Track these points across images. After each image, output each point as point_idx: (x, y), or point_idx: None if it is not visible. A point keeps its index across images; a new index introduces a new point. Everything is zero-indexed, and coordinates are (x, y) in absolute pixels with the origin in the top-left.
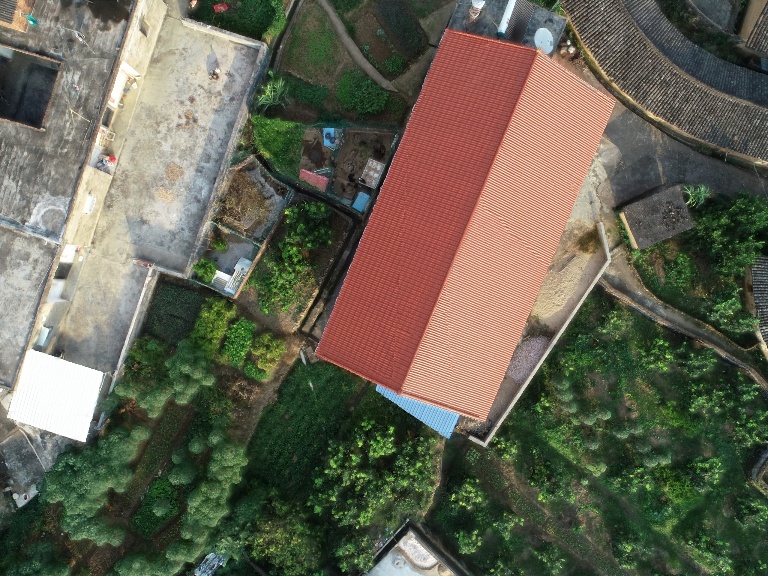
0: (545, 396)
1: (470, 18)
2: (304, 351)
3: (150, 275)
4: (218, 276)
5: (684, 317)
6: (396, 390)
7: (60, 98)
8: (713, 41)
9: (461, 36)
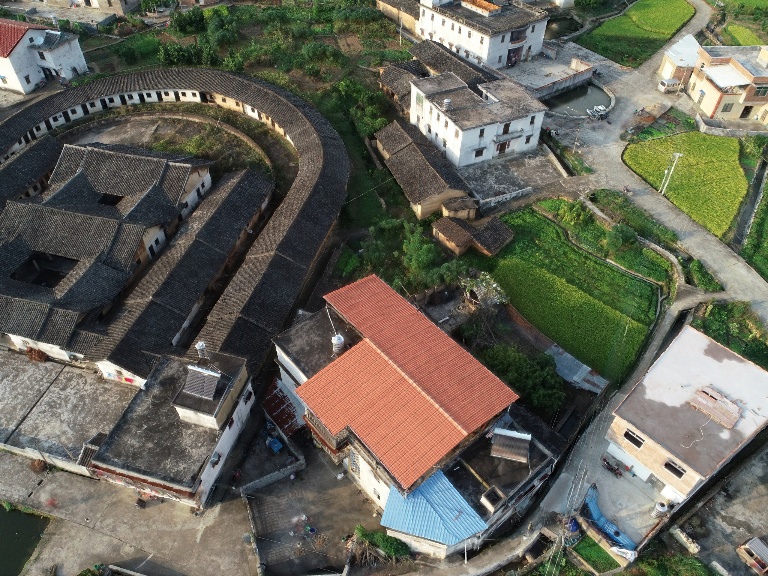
0: None
1: None
2: None
3: None
4: None
5: None
6: None
7: None
8: None
9: None
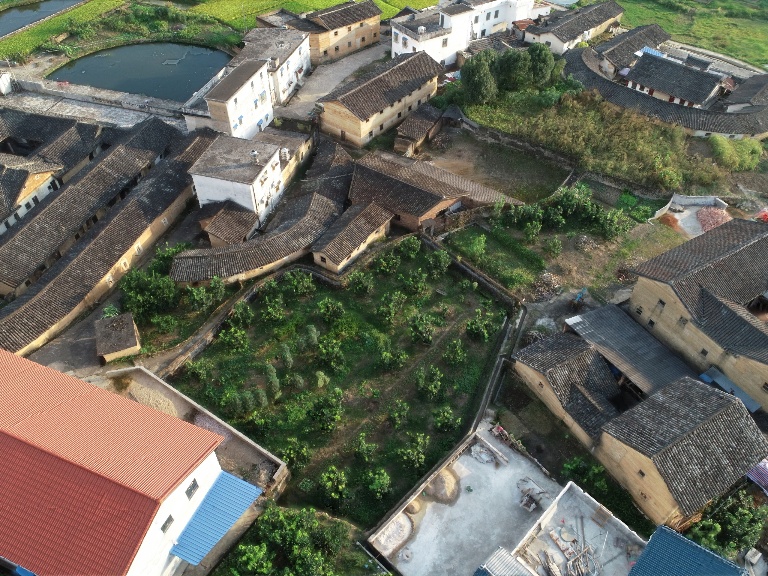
0: None
1: None
2: None
3: None
4: None
5: (208, 323)
6: (156, 505)
7: None
8: None
9: None
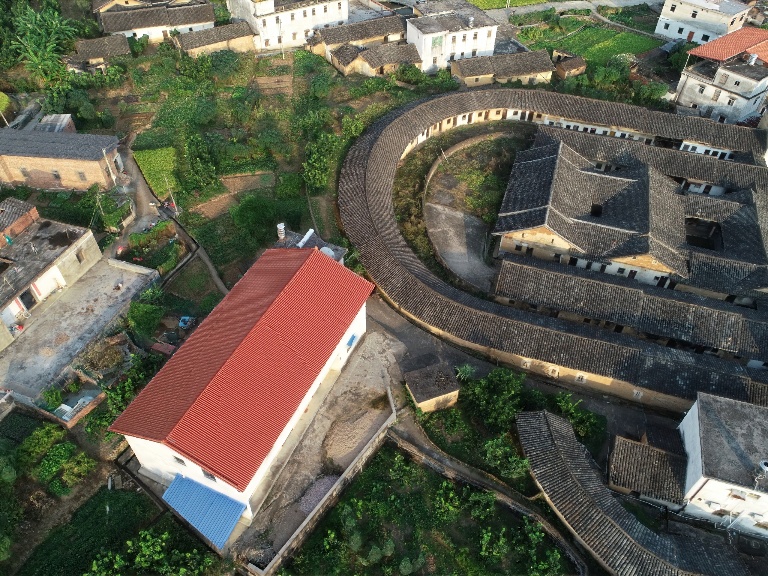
0: (335, 535)
1: (279, 239)
2: (113, 479)
3: (5, 398)
4: (62, 408)
5: (469, 469)
6: (161, 440)
7: (2, 279)
8: (478, 297)
9: (274, 250)
